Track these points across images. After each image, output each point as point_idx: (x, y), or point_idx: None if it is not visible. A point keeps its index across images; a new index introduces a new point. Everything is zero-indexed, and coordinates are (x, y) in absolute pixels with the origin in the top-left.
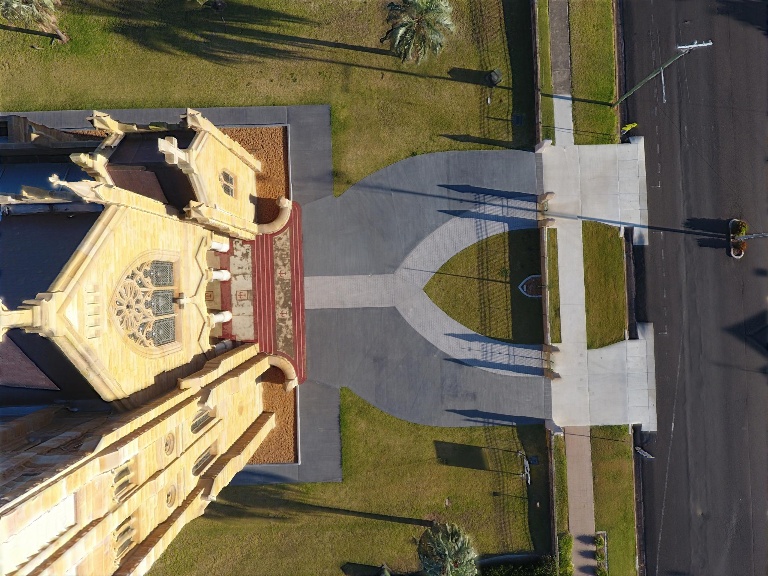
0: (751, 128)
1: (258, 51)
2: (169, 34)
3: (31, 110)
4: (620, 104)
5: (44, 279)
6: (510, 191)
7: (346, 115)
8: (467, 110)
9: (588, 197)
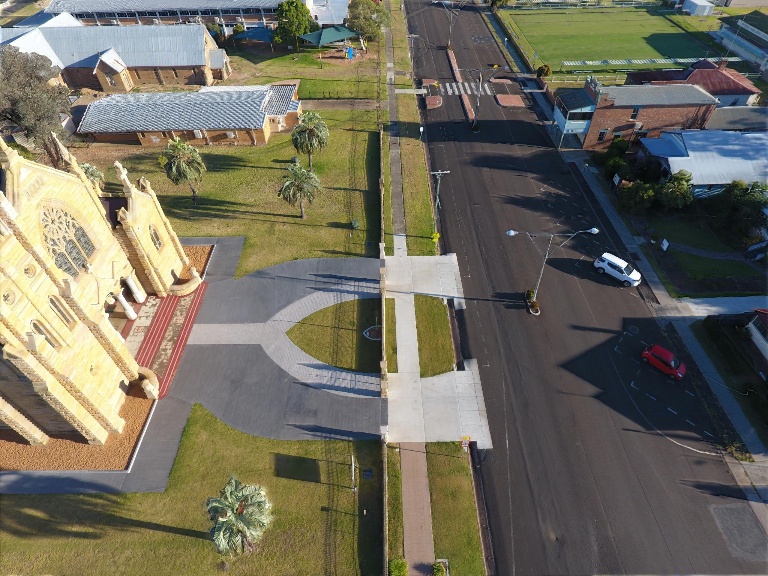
0: (528, 247)
1: (210, 215)
2: None
3: None
4: (439, 239)
5: None
6: (361, 278)
7: (255, 241)
8: (335, 239)
9: (418, 282)
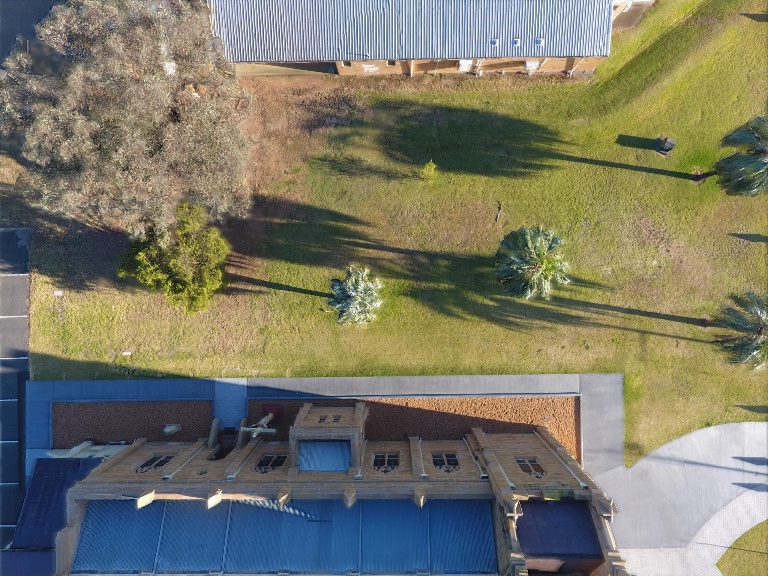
0: None
1: (549, 316)
2: (458, 297)
3: (322, 376)
4: None
5: None
6: None
7: (639, 384)
8: (765, 380)
9: None
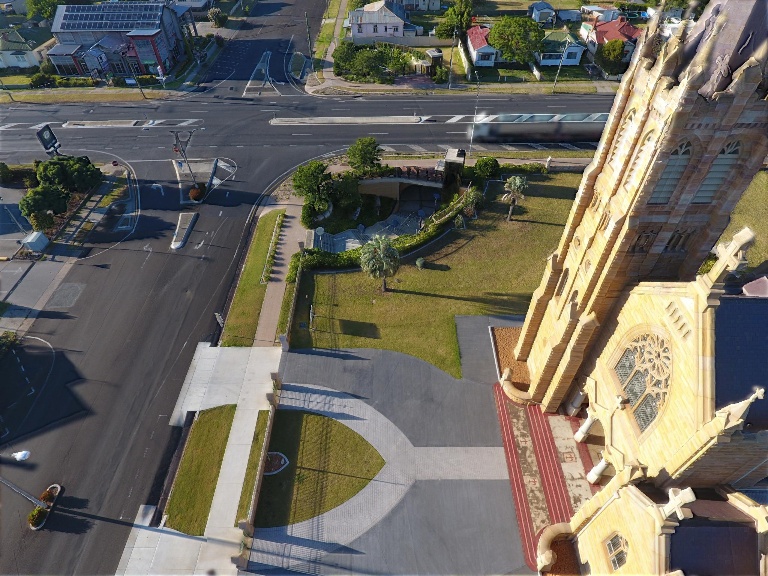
0: None
1: None
2: None
3: None
4: None
5: (730, 338)
6: None
7: None
8: None
9: (187, 567)
